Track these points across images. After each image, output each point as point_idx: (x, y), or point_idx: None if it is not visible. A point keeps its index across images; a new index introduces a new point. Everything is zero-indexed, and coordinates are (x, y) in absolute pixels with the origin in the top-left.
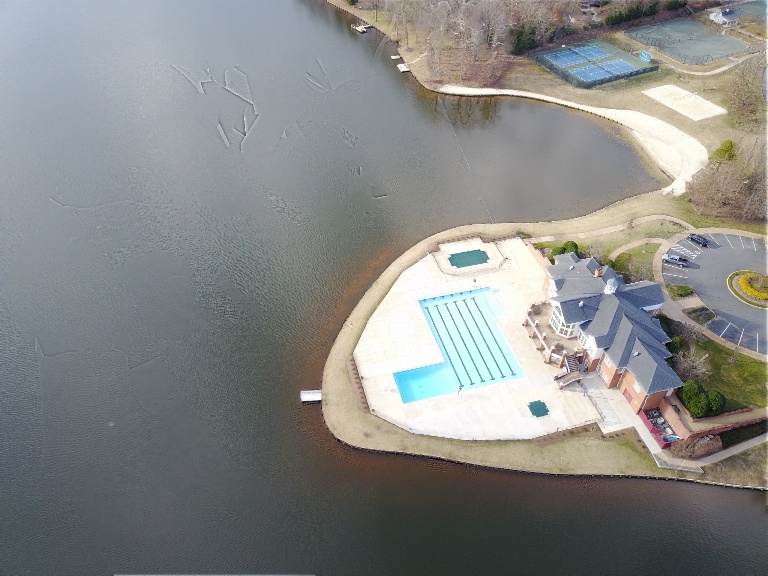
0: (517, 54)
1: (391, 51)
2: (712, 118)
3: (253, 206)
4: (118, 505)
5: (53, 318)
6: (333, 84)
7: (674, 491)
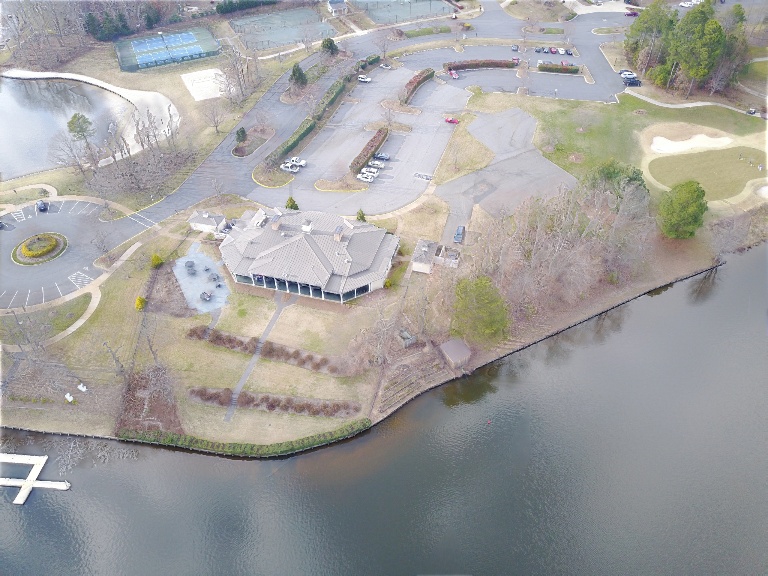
0: (106, 40)
1: None
2: (214, 99)
3: None
4: None
5: None
6: None
7: None
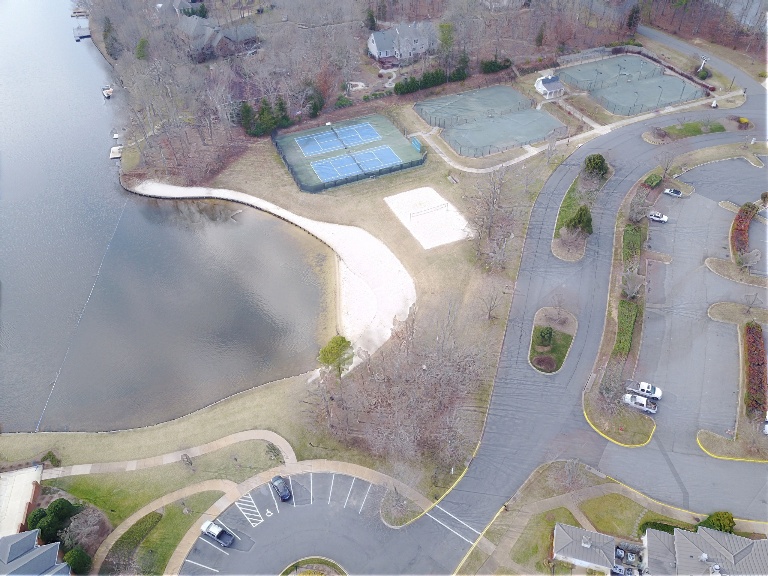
0: (261, 136)
1: None
2: (450, 245)
3: None
4: None
5: None
6: (9, 177)
7: None
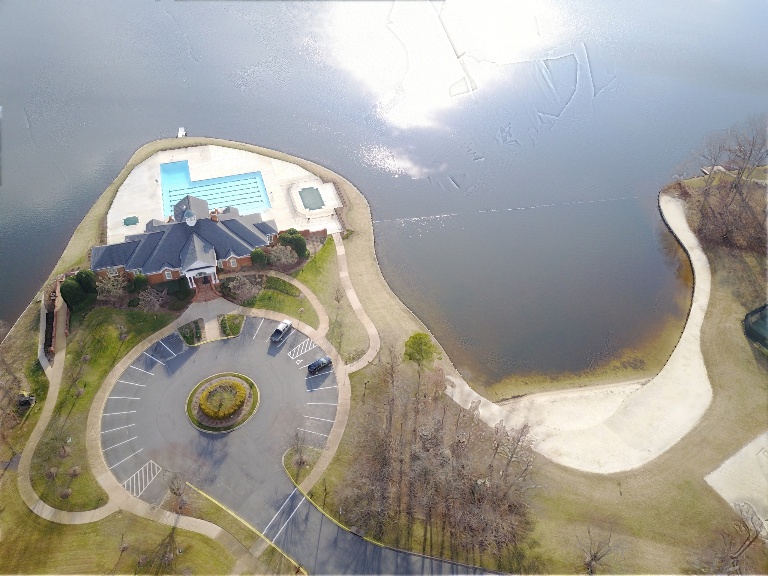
0: None
1: (762, 162)
2: (731, 513)
3: (364, 86)
4: (99, 60)
5: (186, 3)
6: (632, 124)
7: (36, 286)
